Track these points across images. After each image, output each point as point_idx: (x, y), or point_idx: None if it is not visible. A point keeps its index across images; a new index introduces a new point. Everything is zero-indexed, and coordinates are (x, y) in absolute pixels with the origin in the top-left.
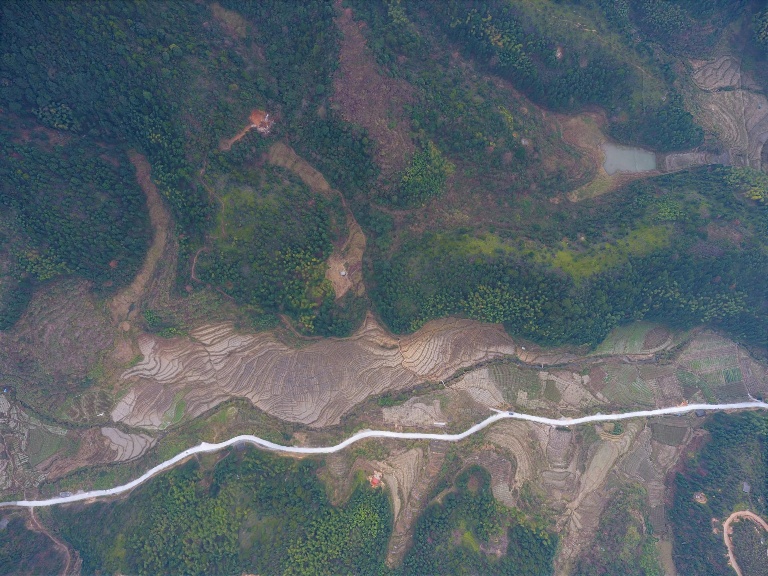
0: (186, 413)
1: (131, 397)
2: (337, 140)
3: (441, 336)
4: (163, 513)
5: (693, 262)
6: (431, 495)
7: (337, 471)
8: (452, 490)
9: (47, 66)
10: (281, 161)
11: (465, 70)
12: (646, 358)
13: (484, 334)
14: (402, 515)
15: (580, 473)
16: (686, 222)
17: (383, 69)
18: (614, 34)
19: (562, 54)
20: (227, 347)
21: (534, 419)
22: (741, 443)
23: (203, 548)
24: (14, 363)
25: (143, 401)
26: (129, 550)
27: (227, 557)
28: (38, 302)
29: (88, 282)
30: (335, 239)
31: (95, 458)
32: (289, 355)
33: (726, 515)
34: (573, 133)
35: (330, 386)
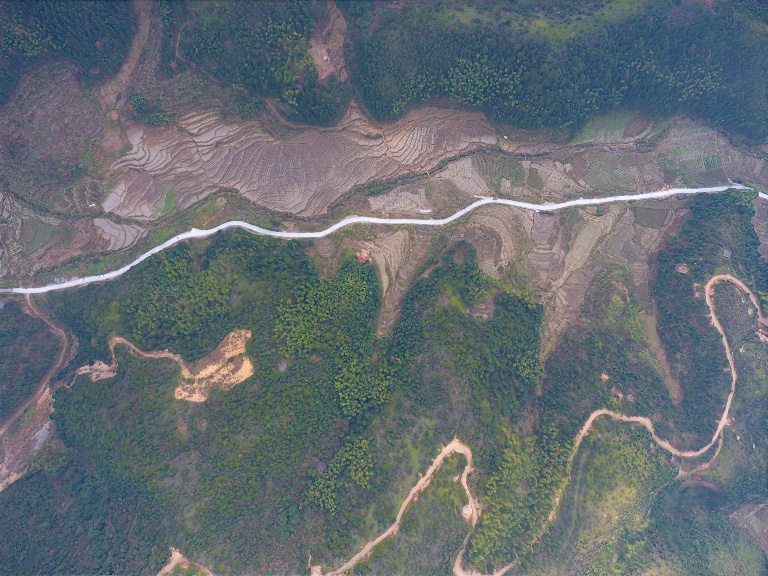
0: (176, 204)
1: (121, 188)
2: None
3: (424, 126)
4: (155, 285)
5: (667, 25)
6: (418, 272)
7: (325, 252)
8: (438, 265)
9: None
10: None
11: None
12: (627, 146)
13: (467, 125)
14: (390, 292)
15: (564, 253)
16: None
17: None
18: None
19: None
20: (214, 137)
21: (518, 204)
22: (721, 214)
23: (195, 313)
24: (5, 148)
25: (133, 192)
26: (123, 314)
27: (219, 318)
28: (26, 85)
29: (75, 66)
30: (316, 18)
31: (88, 247)
32: (275, 147)
33: (707, 278)
34: None
35: (317, 176)
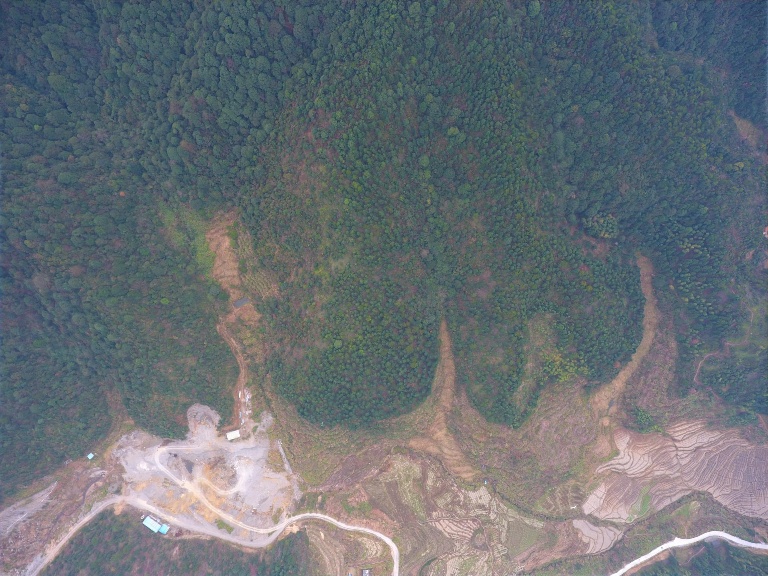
0: (651, 506)
1: (602, 490)
2: None
3: None
4: None
5: None
6: None
7: None
8: None
9: (620, 182)
10: None
11: None
12: None
13: None
14: None
15: None
16: None
17: None
18: None
19: None
20: (695, 443)
21: None
22: None
23: None
24: (510, 458)
25: (612, 494)
26: None
27: None
28: (540, 400)
29: (585, 380)
30: None
31: (569, 550)
32: (748, 451)
33: None
34: None
35: None
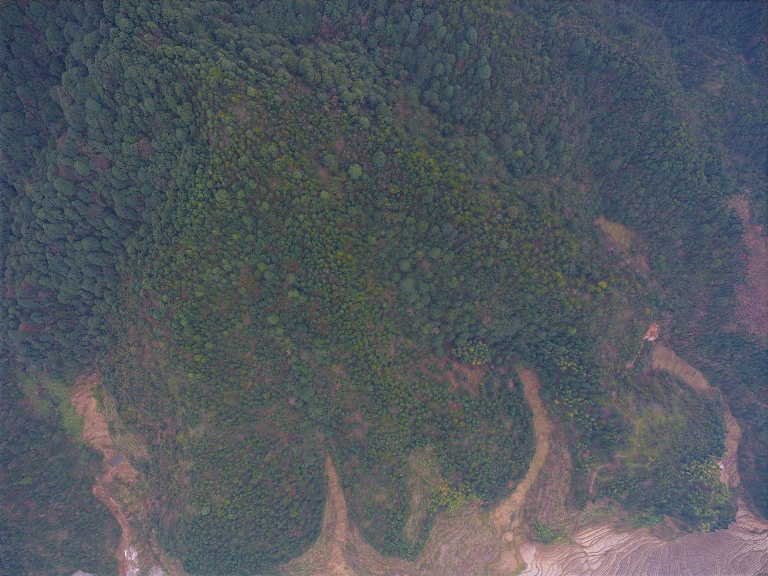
0: None
1: None
2: (736, 349)
3: None
4: None
5: None
6: None
7: None
8: None
9: (482, 314)
10: (663, 364)
11: None
12: None
13: None
14: None
15: None
16: None
17: None
18: None
19: None
20: (604, 547)
21: None
22: None
23: None
24: None
25: None
26: None
27: None
28: (436, 527)
29: (480, 501)
30: (722, 439)
31: None
32: (661, 547)
33: None
34: None
35: (704, 575)
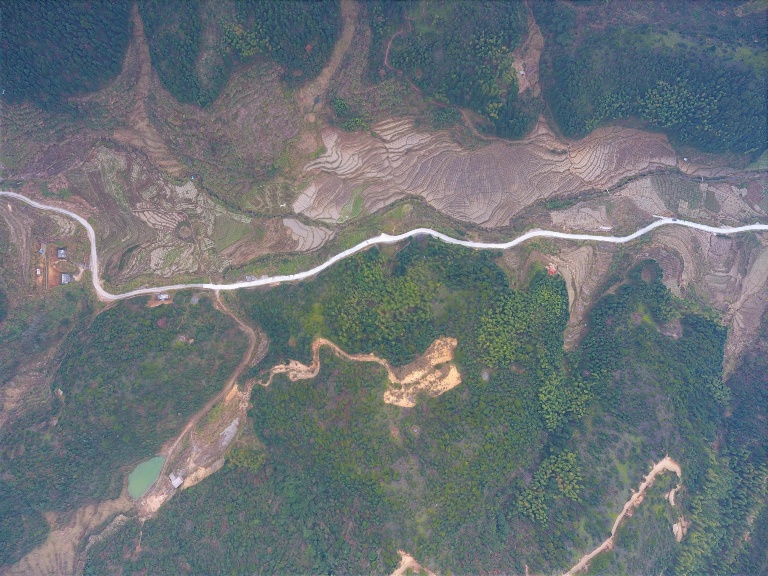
0: (363, 209)
1: (312, 190)
2: None
3: (607, 145)
4: (354, 288)
5: None
6: (603, 288)
7: (512, 264)
8: (624, 283)
9: None
10: None
11: None
12: None
13: (647, 145)
14: (575, 307)
15: (741, 277)
16: None
17: None
18: None
19: None
20: (405, 144)
21: (696, 226)
22: None
23: (397, 318)
24: (208, 145)
25: (323, 194)
26: (327, 316)
27: (422, 324)
28: (234, 84)
29: (281, 68)
30: (520, 33)
31: (277, 246)
32: (462, 157)
33: None
34: None
35: (501, 188)
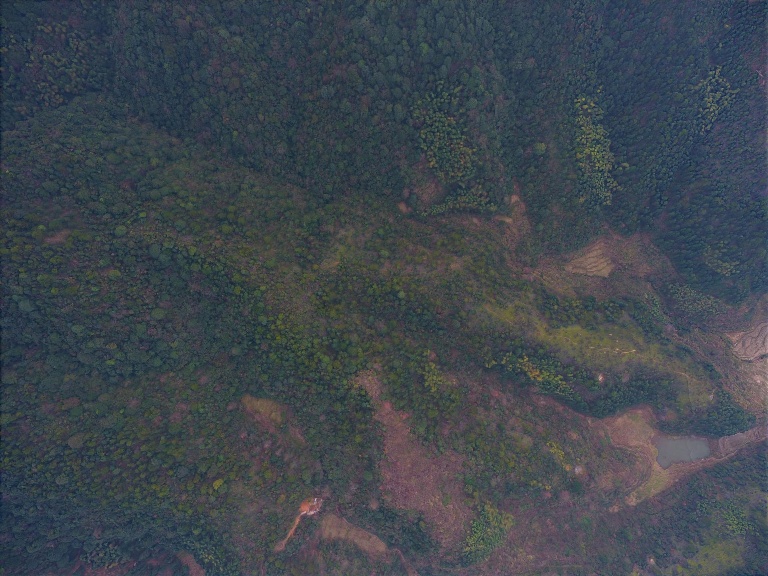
0: None
1: None
2: (392, 520)
3: None
4: None
5: None
6: None
7: None
8: None
9: (92, 527)
10: (334, 533)
11: (507, 405)
12: None
13: None
14: None
15: None
16: (757, 538)
17: (430, 449)
18: (652, 345)
19: (604, 378)
20: None
21: None
22: None
23: None
24: None
25: None
26: None
27: None
28: None
29: None
30: None
31: None
32: None
33: None
34: (622, 433)
35: None
